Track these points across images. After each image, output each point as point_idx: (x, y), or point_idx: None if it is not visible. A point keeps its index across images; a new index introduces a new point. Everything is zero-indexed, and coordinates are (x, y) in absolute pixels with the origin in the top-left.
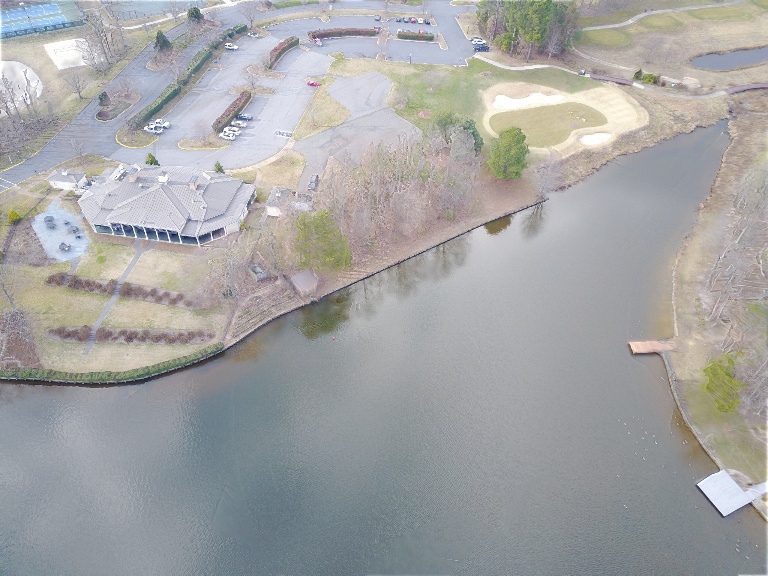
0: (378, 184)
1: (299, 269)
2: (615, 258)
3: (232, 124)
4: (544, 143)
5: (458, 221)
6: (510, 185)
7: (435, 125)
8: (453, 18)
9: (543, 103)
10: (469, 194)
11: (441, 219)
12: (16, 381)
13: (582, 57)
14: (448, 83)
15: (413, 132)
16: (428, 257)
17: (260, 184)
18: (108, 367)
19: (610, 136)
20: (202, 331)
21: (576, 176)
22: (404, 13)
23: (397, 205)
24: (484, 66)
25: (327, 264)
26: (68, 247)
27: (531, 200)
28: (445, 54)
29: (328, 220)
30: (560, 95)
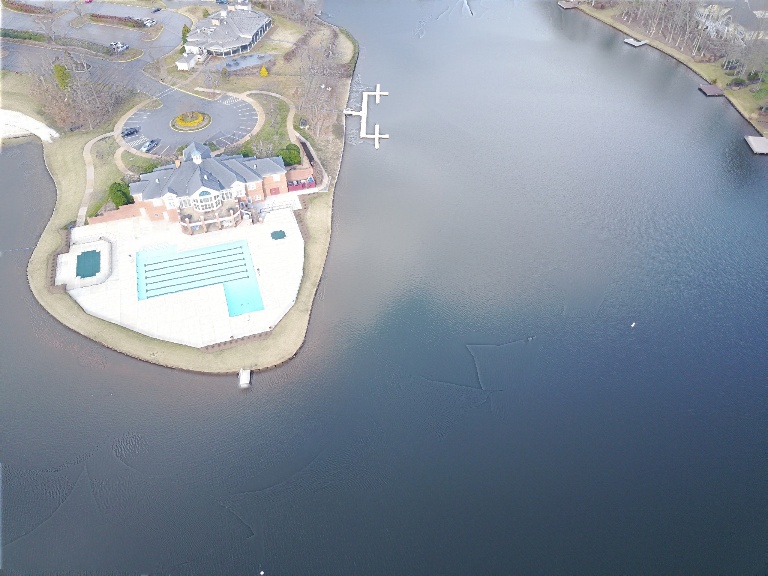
0: None
1: None
2: None
3: None
4: None
5: None
6: None
7: None
8: None
9: None
10: None
11: None
12: None
13: None
14: None
15: None
16: None
17: None
18: (350, 49)
19: None
20: None
21: None
22: None
23: None
24: None
25: None
26: None
27: None
28: None
29: None
30: None
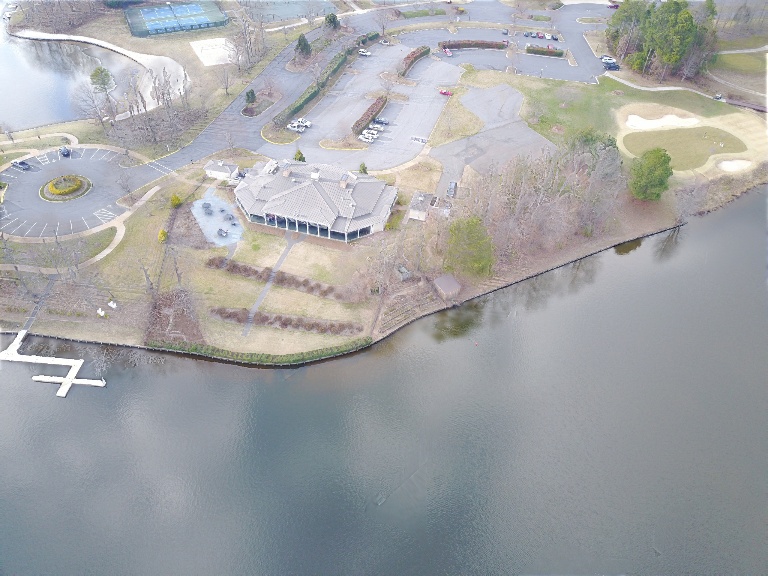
0: (531, 195)
1: (441, 272)
2: (760, 289)
3: (370, 127)
4: (681, 166)
5: (595, 238)
6: (647, 206)
7: (575, 141)
8: (581, 35)
9: (678, 125)
10: (610, 212)
11: (578, 235)
12: (182, 354)
13: (716, 81)
14: (580, 100)
15: (561, 146)
16: (563, 272)
17: (400, 187)
18: (265, 350)
19: (750, 164)
20: (352, 324)
21: (715, 202)
22: (531, 28)
23: (540, 217)
24: (615, 85)
25: (474, 270)
26: (225, 233)
27: (670, 223)
28: (575, 71)
29: (481, 227)
30: (695, 118)
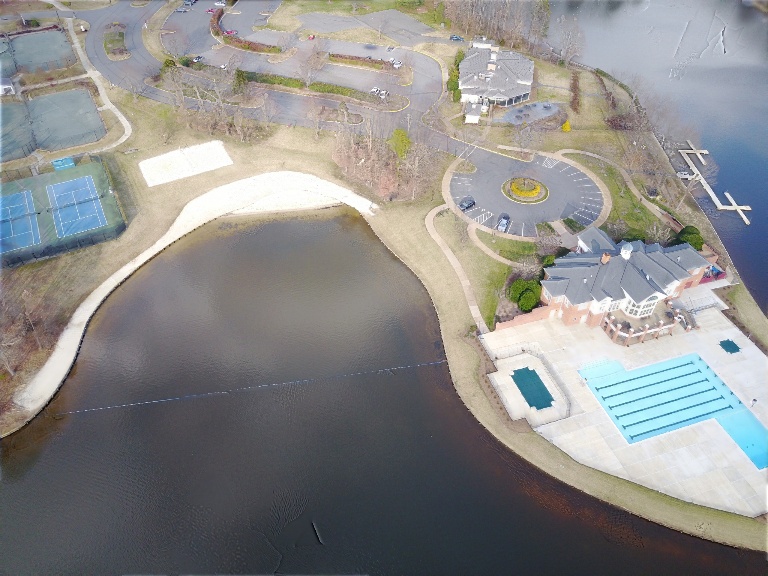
0: None
1: None
2: None
3: None
4: None
5: None
6: None
7: None
8: None
9: None
10: None
11: None
12: None
13: None
14: None
15: None
16: None
17: None
18: (626, 96)
19: None
20: None
21: None
22: (175, 1)
23: None
24: None
25: None
26: None
27: None
28: None
29: None
30: None
